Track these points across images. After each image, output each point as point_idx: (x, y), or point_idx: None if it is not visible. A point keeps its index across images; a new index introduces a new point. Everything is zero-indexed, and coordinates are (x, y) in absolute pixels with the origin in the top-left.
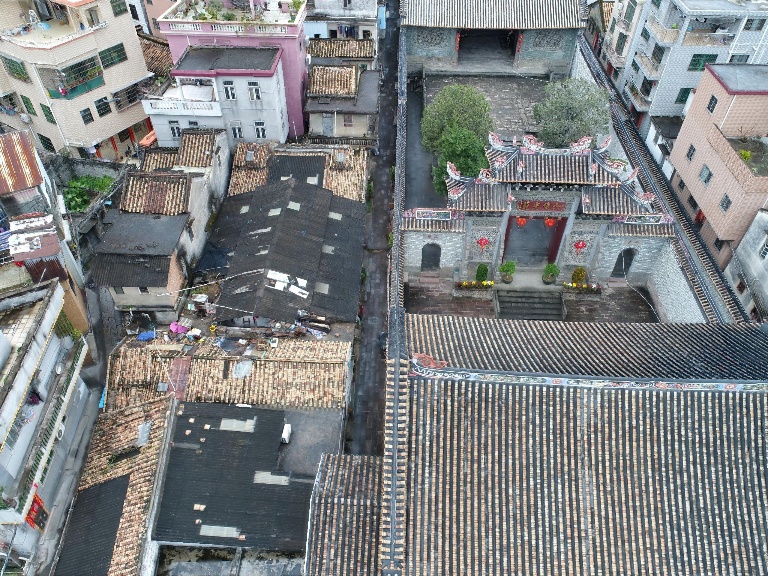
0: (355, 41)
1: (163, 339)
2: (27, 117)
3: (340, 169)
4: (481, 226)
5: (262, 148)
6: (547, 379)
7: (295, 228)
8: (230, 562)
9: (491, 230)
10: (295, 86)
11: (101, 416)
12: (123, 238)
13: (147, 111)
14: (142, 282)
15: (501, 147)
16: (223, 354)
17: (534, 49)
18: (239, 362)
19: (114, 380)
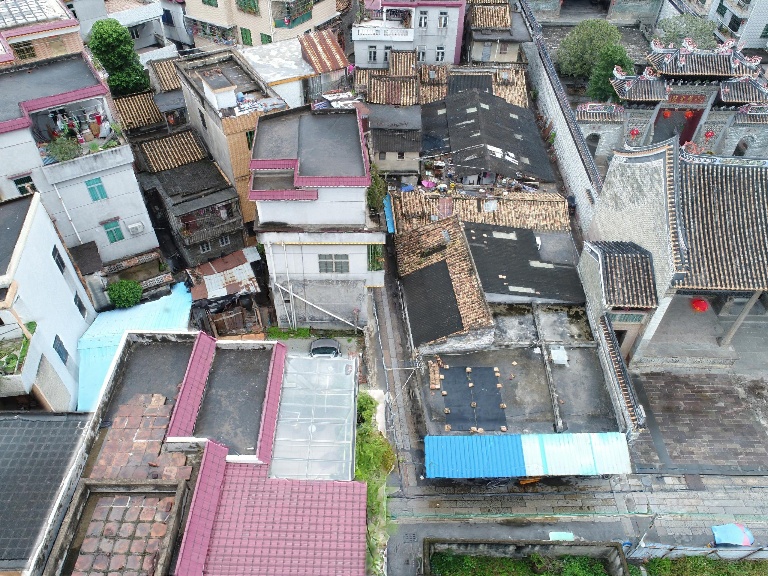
0: None
1: None
2: (242, 47)
3: (505, 85)
4: (636, 118)
5: (441, 69)
6: (767, 162)
7: (492, 120)
8: (529, 310)
9: (643, 121)
10: (460, 21)
11: (397, 235)
12: (379, 119)
13: (354, 37)
14: (403, 148)
15: (662, 50)
16: None
17: (626, 3)
18: (487, 201)
19: (398, 213)
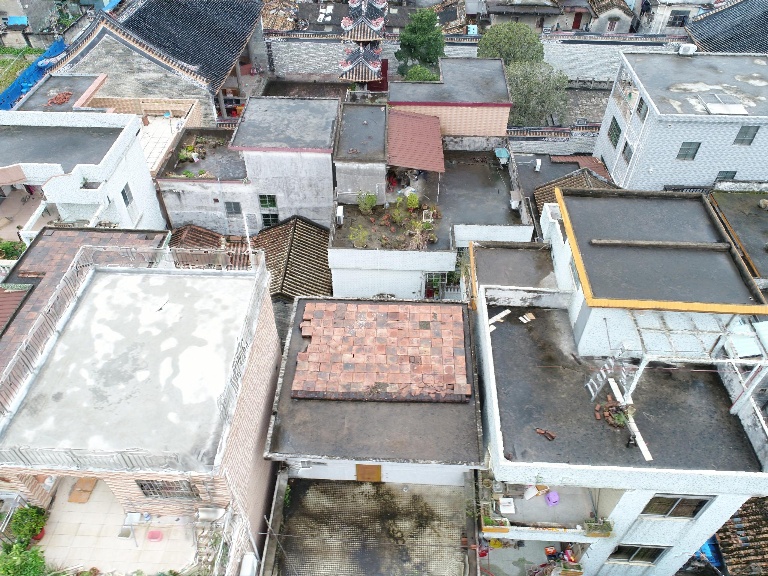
0: (610, 1)
1: (301, 0)
2: None
3: None
4: None
5: None
6: None
7: None
8: None
9: None
10: None
11: None
12: None
13: None
14: None
15: None
16: (284, 7)
17: None
18: None
19: None
